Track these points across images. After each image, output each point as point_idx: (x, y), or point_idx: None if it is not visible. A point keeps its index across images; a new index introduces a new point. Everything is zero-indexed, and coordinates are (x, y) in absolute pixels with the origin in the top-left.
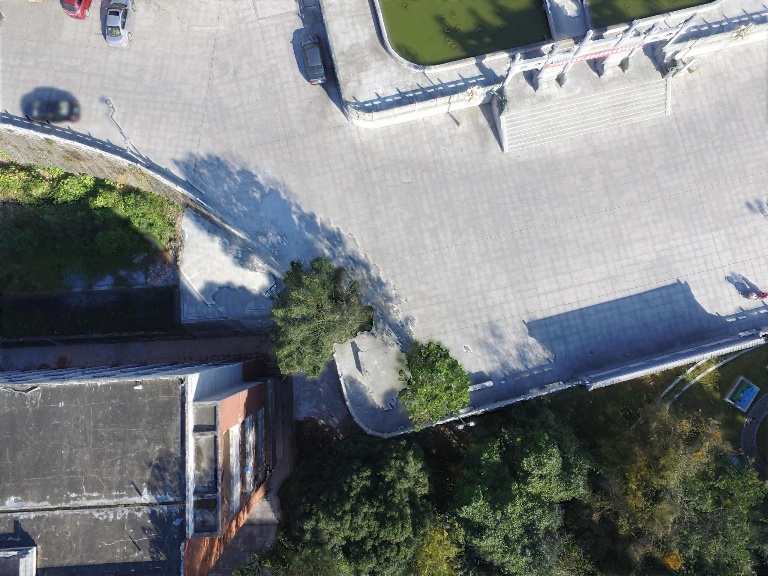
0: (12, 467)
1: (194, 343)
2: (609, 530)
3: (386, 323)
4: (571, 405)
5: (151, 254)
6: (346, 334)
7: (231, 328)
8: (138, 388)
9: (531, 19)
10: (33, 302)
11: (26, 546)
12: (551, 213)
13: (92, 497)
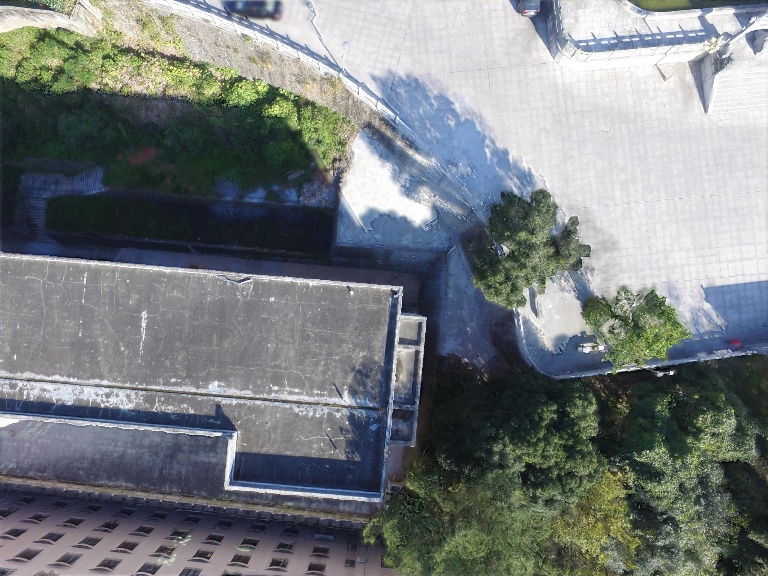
0: (218, 353)
1: (326, 270)
2: (765, 494)
3: None
4: (727, 375)
5: (308, 173)
6: (547, 271)
7: (374, 258)
8: (352, 293)
9: None
10: (180, 205)
11: (227, 430)
12: (745, 182)
13: (294, 392)
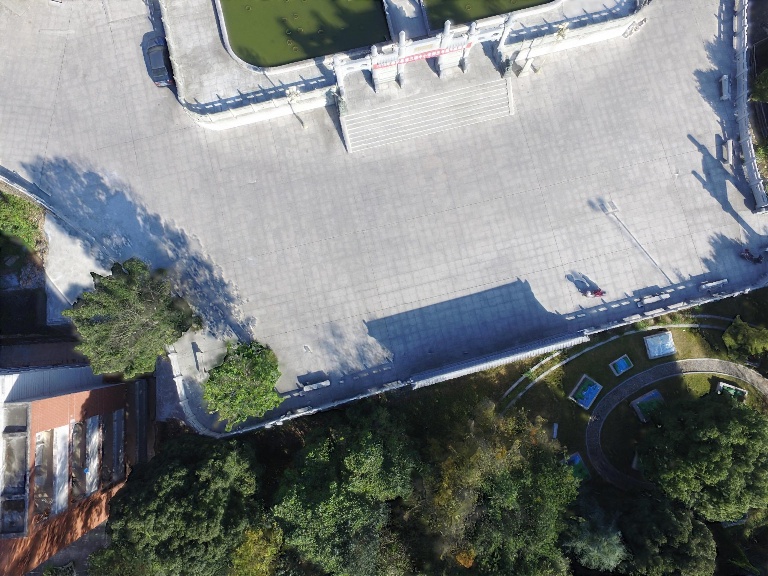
0: None
1: None
2: None
3: (227, 323)
4: (416, 404)
5: (22, 257)
6: (167, 334)
7: None
8: None
9: (372, 20)
10: None
11: None
12: (394, 213)
13: None
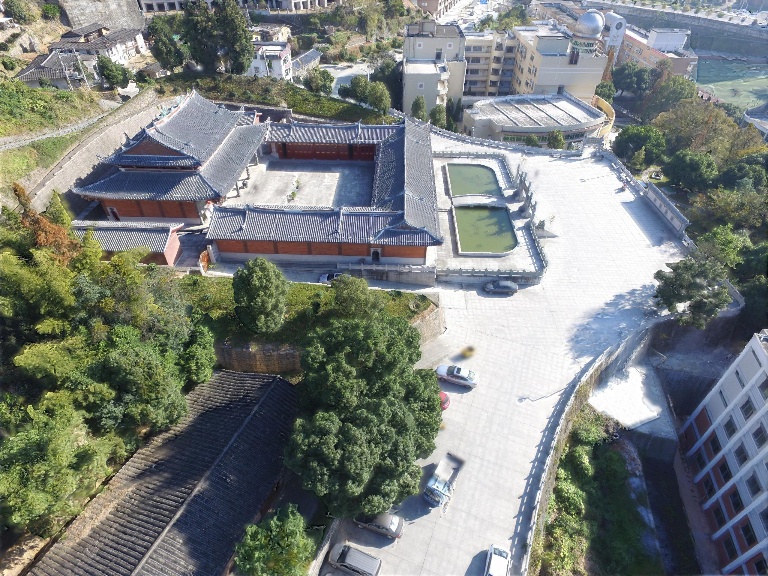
0: None
1: None
2: (759, 234)
3: None
4: None
5: None
6: None
7: None
8: None
9: (493, 212)
10: None
11: None
12: (591, 229)
13: None
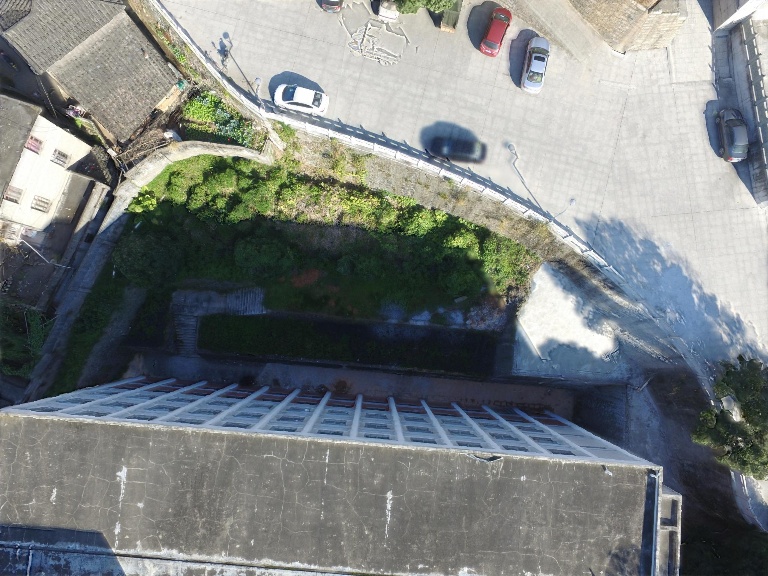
0: (467, 536)
1: (477, 385)
2: None
3: None
4: None
5: (477, 296)
6: None
7: (538, 381)
8: (609, 474)
9: None
10: (339, 326)
11: None
12: None
13: None
